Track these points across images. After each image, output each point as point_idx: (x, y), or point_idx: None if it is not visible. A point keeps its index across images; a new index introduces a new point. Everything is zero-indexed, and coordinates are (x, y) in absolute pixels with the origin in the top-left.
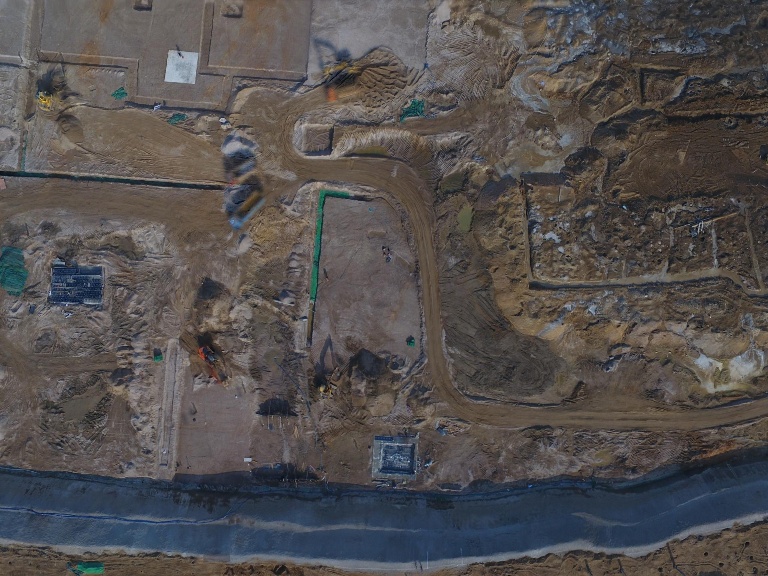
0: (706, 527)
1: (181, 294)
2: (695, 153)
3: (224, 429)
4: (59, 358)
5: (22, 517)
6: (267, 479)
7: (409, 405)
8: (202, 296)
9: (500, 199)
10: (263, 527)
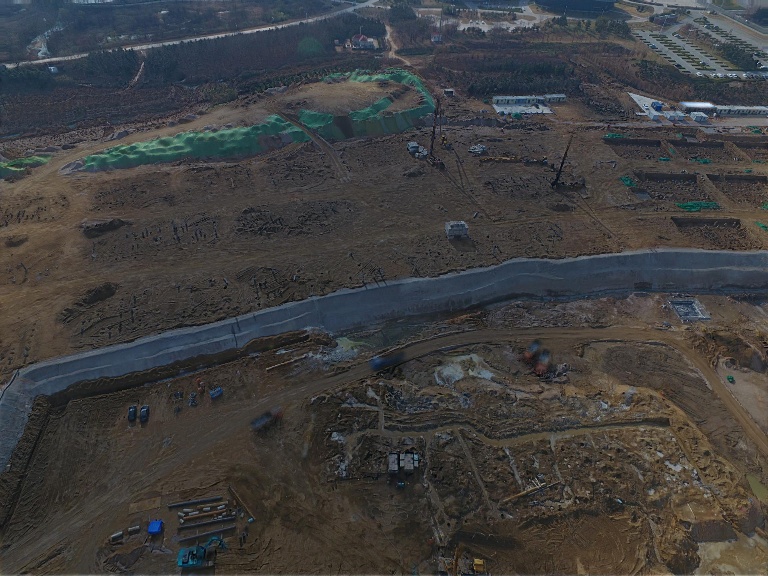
0: (479, 271)
1: None
2: (567, 574)
3: None
4: None
5: None
6: (764, 296)
7: None
8: None
9: (748, 502)
10: (756, 268)
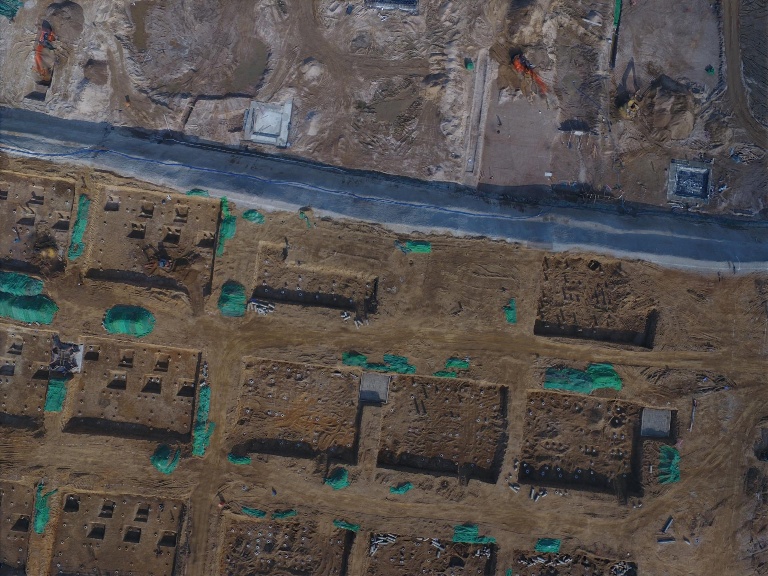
0: None
1: (494, 6)
2: None
3: (527, 143)
4: (373, 60)
5: (346, 199)
6: (566, 194)
7: (707, 130)
8: (518, 6)
9: None
10: (577, 225)
